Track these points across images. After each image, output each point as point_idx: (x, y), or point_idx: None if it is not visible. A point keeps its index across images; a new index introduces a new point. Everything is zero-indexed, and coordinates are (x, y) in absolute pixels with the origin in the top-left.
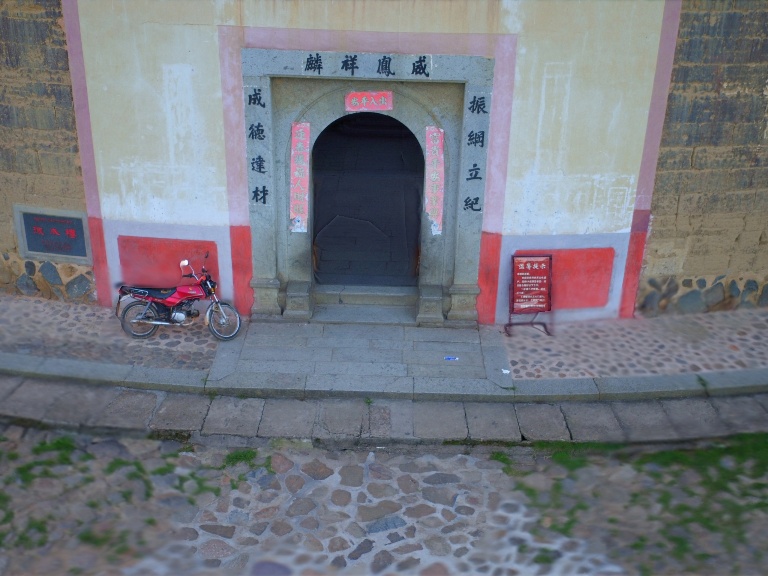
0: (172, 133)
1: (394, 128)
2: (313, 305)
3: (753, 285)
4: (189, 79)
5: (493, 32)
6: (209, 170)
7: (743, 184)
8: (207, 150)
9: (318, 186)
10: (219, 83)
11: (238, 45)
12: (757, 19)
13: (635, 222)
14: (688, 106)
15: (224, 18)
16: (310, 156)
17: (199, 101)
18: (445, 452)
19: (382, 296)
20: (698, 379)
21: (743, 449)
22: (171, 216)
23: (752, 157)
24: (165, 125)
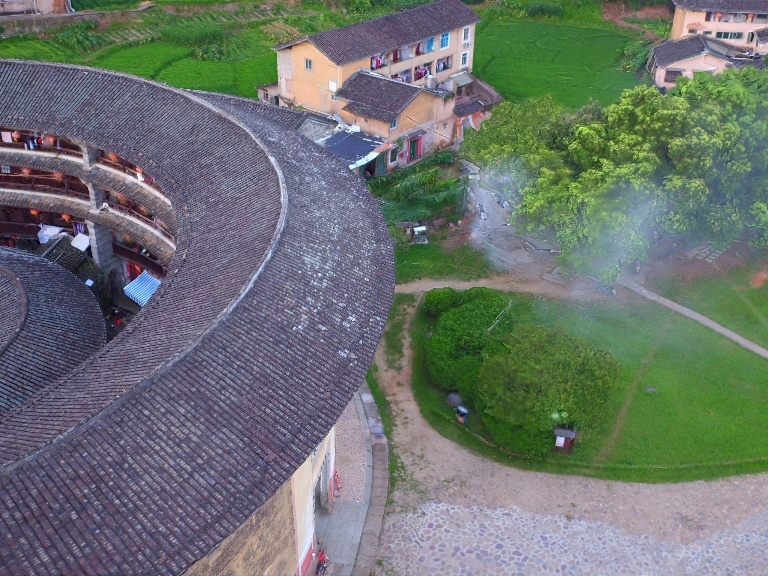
0: None
1: None
2: None
3: None
4: None
5: None
6: None
7: None
8: None
9: None
10: None
11: None
12: None
13: None
14: None
15: None
16: None
17: None
18: (385, 523)
19: None
20: (369, 466)
21: (392, 470)
22: None
23: None
24: None
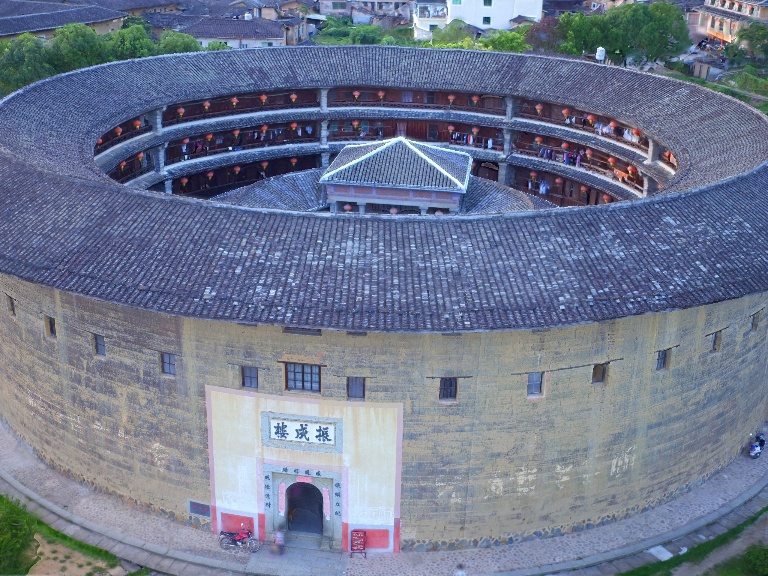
0: (240, 485)
1: (313, 487)
2: (286, 540)
3: (445, 543)
4: (247, 470)
5: (341, 466)
6: (252, 496)
7: (434, 511)
8: (251, 491)
9: (289, 500)
10: (256, 472)
11: (262, 463)
12: (429, 464)
13: (395, 522)
14: (409, 488)
15: (258, 455)
16: (285, 493)
17: (249, 477)
18: None
19: (311, 537)
20: None
21: None
22: (239, 508)
23: (435, 503)
24: (238, 482)
